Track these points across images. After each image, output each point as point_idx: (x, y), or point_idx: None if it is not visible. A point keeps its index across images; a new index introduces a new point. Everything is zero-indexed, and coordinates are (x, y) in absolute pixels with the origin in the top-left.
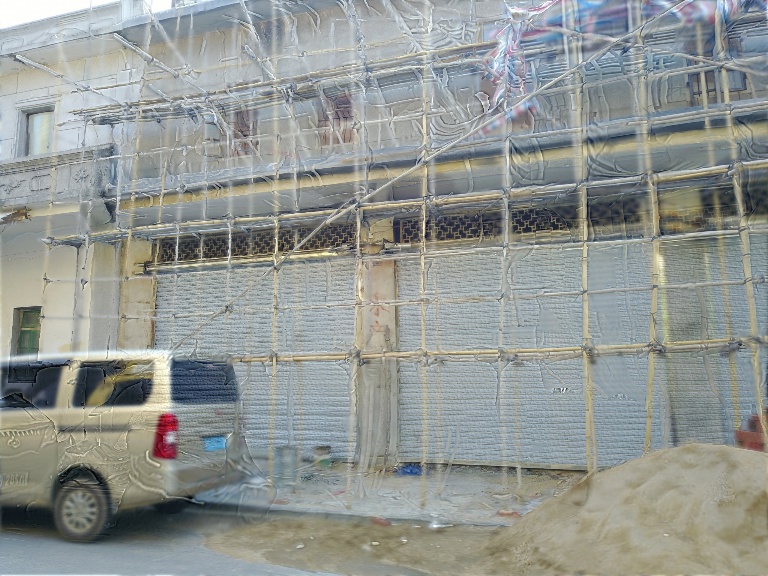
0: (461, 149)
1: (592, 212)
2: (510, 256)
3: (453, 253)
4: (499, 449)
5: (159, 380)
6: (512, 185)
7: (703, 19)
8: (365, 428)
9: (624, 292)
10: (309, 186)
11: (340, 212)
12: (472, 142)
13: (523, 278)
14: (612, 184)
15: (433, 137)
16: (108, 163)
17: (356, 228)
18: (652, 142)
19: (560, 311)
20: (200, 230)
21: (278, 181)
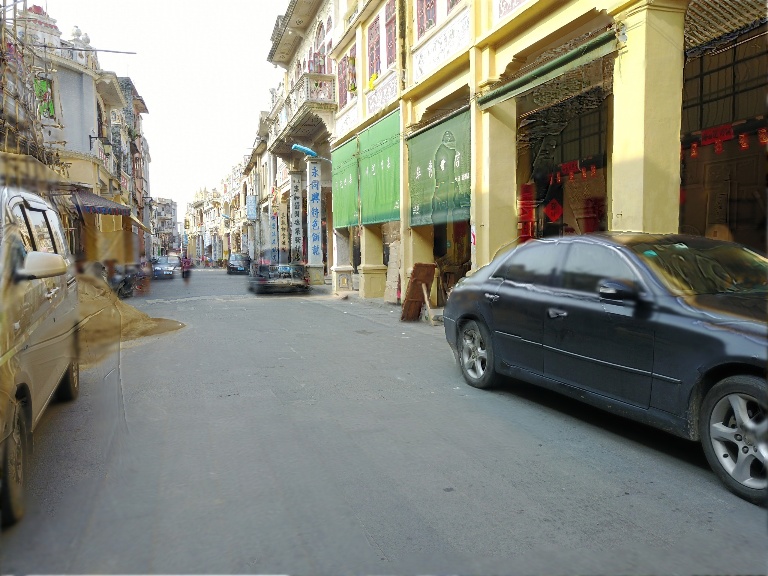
0: None
1: None
2: None
3: None
4: None
5: None
6: None
7: (0, 24)
8: None
9: None
10: None
11: None
12: None
13: None
14: None
15: None
16: None
17: None
18: None
19: None
20: None
21: None
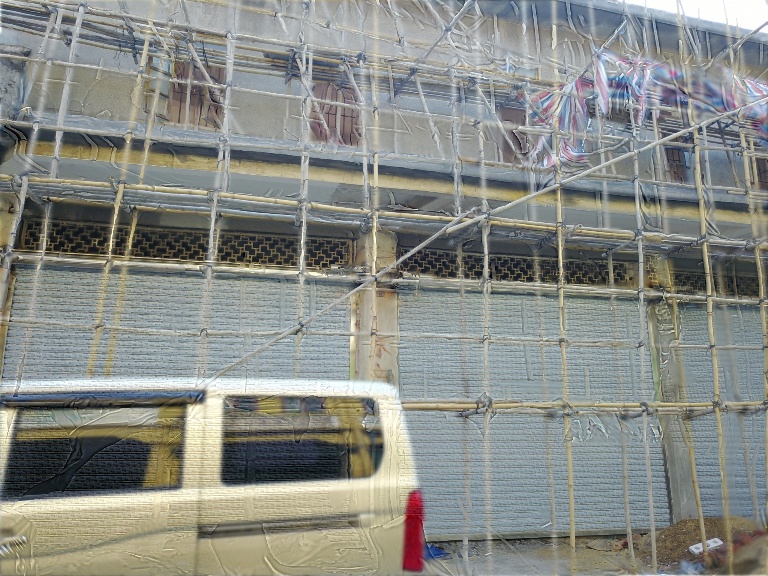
0: (595, 179)
1: (714, 268)
2: (647, 302)
3: (589, 291)
4: (514, 518)
5: (5, 436)
6: (641, 228)
7: None
8: (366, 500)
9: (743, 350)
10: (358, 184)
11: (463, 222)
12: (605, 175)
13: (534, 329)
14: (725, 245)
15: (561, 160)
16: (16, 75)
17: (348, 248)
18: (746, 213)
19: (697, 364)
20: (231, 209)
21: (317, 168)
